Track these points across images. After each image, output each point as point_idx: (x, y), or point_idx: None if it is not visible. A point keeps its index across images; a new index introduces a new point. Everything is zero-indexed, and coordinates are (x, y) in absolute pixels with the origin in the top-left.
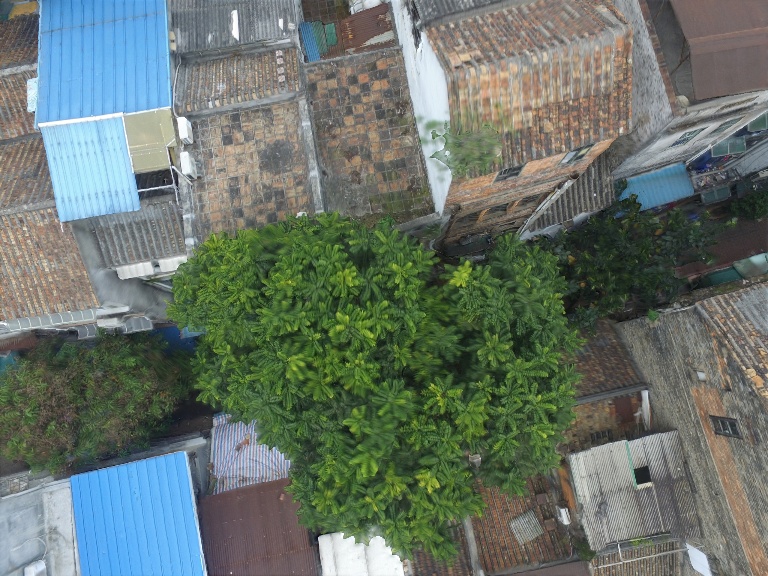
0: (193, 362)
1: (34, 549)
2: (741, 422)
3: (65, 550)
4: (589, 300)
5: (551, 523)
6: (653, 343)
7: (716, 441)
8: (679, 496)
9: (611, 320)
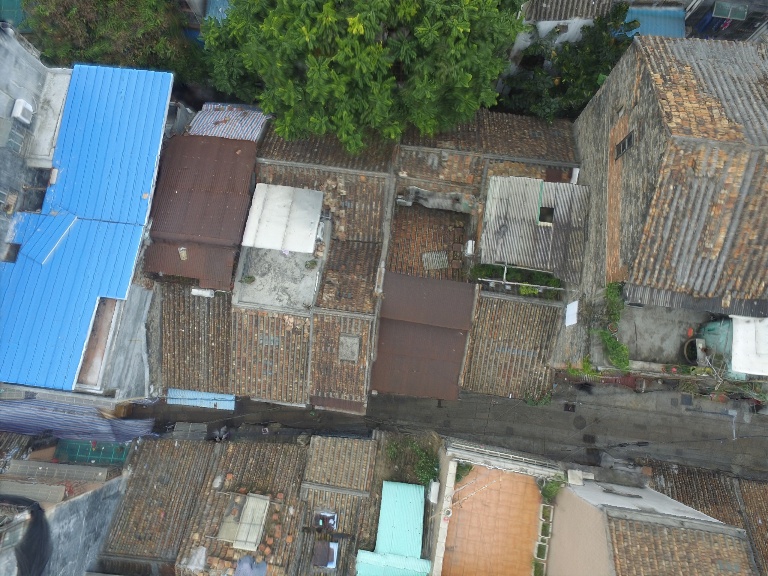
0: (203, 24)
1: (27, 102)
2: (636, 128)
3: (51, 119)
4: (560, 113)
5: (458, 263)
6: (595, 113)
7: (614, 168)
8: (572, 243)
9: (571, 123)
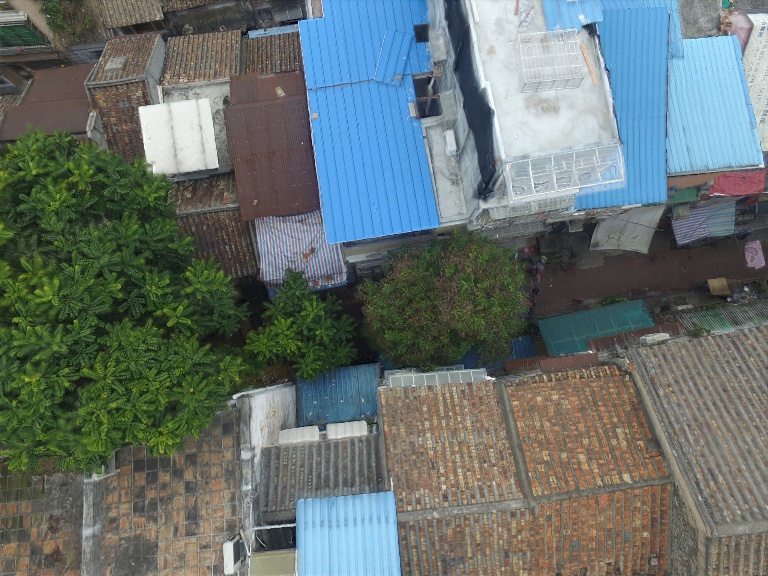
0: None
1: None
2: None
3: (442, 166)
4: None
5: None
6: None
7: None
8: None
9: None
